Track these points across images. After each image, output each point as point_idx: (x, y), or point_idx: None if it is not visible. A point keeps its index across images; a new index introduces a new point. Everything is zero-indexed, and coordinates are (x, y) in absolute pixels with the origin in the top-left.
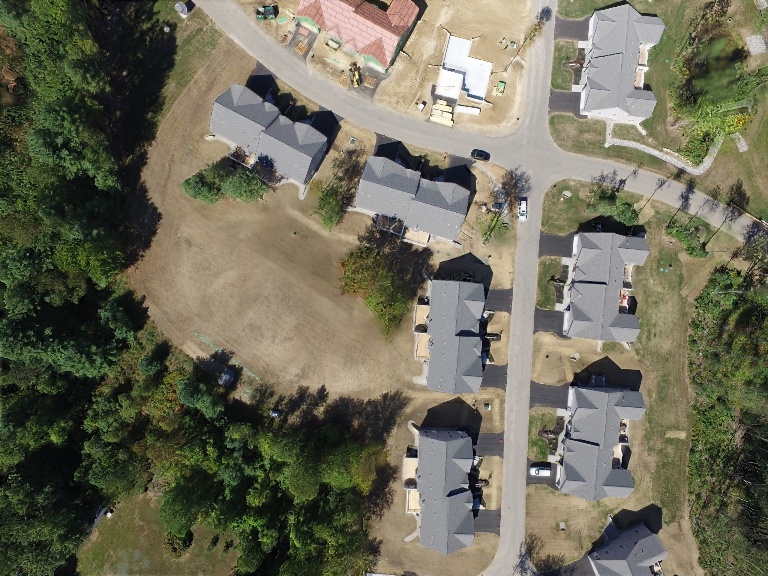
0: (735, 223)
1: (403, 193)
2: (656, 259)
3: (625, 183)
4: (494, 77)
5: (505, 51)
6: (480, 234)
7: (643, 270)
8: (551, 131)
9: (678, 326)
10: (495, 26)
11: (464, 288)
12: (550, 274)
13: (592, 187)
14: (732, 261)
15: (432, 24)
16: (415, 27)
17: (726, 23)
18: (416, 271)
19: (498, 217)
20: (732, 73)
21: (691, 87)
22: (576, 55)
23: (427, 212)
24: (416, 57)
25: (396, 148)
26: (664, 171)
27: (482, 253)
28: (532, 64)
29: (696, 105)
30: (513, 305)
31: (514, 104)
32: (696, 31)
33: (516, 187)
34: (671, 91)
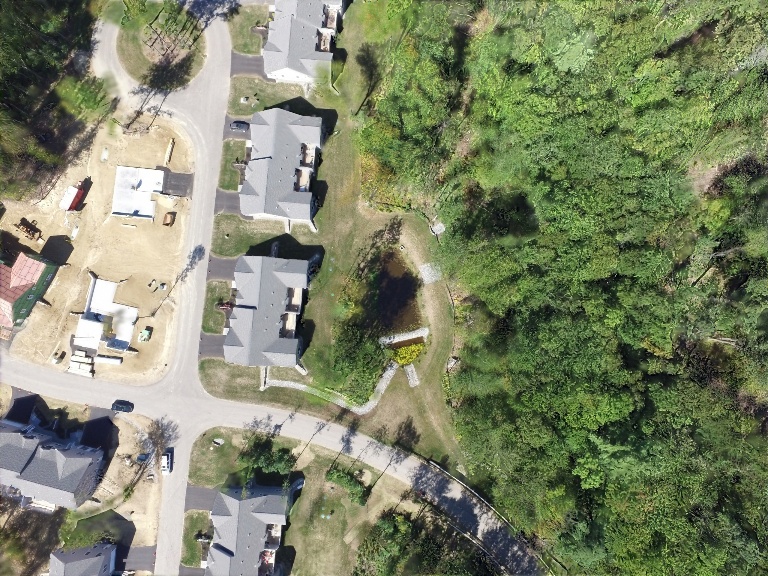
0: (401, 466)
1: (8, 471)
2: (317, 505)
3: (280, 429)
4: (140, 322)
5: (154, 293)
6: (122, 489)
7: (303, 517)
8: (201, 377)
9: (340, 575)
10: (145, 267)
11: (73, 568)
12: (197, 528)
13: (245, 434)
14: (402, 503)
15: (78, 267)
16: (57, 273)
17: (399, 250)
18: (52, 531)
19: (144, 469)
20: (407, 302)
21: (358, 321)
22: (230, 295)
23: (36, 488)
24: (58, 304)
25: (33, 401)
26: (324, 413)
27: (124, 509)
28: (182, 307)
29: (363, 340)
30: (156, 563)
31: (163, 349)
32: (365, 261)
33: (163, 437)
34: (334, 327)
